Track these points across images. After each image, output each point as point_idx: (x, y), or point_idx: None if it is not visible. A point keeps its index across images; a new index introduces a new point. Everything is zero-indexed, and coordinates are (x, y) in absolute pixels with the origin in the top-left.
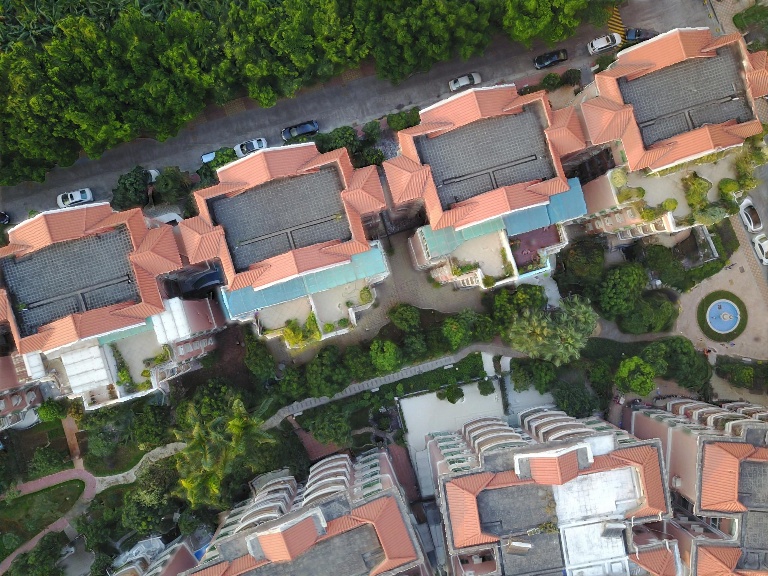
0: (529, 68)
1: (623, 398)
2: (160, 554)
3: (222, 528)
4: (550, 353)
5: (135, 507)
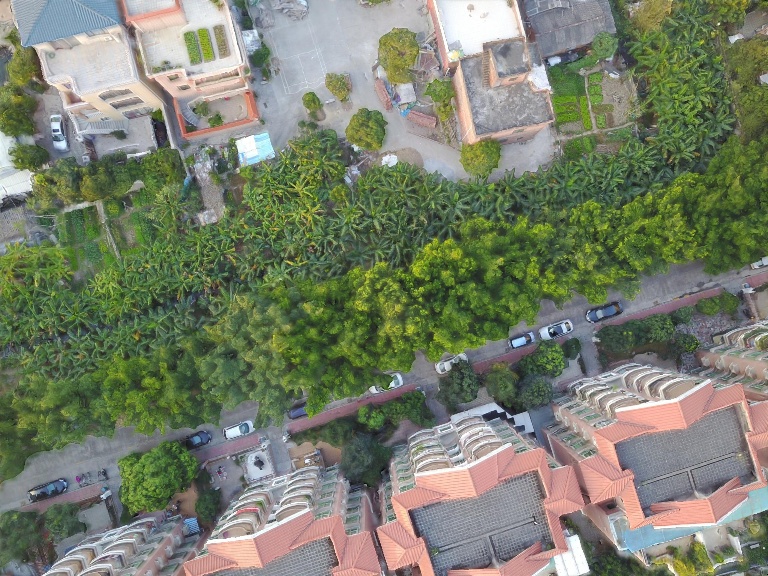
0: None
1: None
2: None
3: None
4: None
5: None
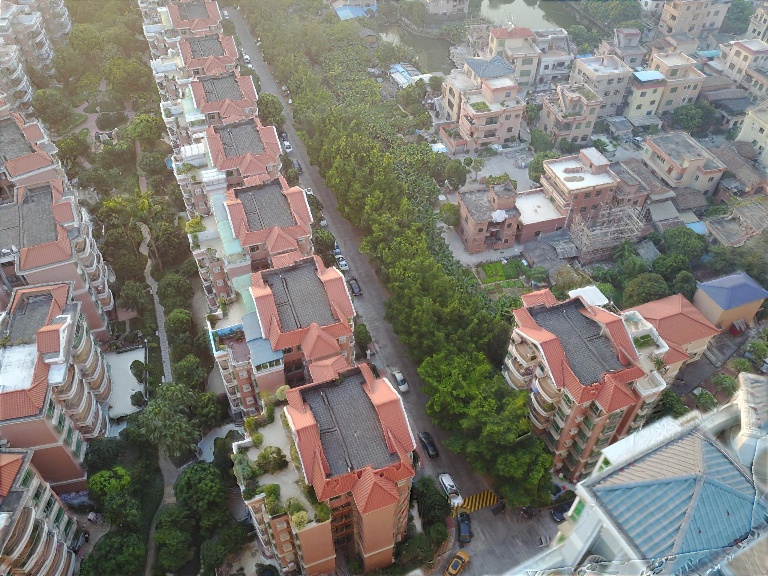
0: (418, 427)
1: (94, 515)
2: None
3: None
4: None
5: None
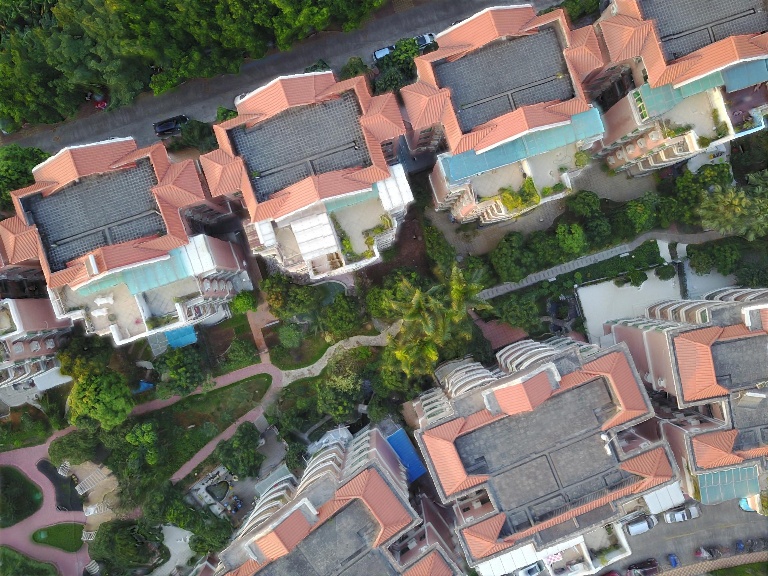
0: None
1: None
2: (353, 440)
3: (425, 405)
4: (745, 227)
5: (332, 392)
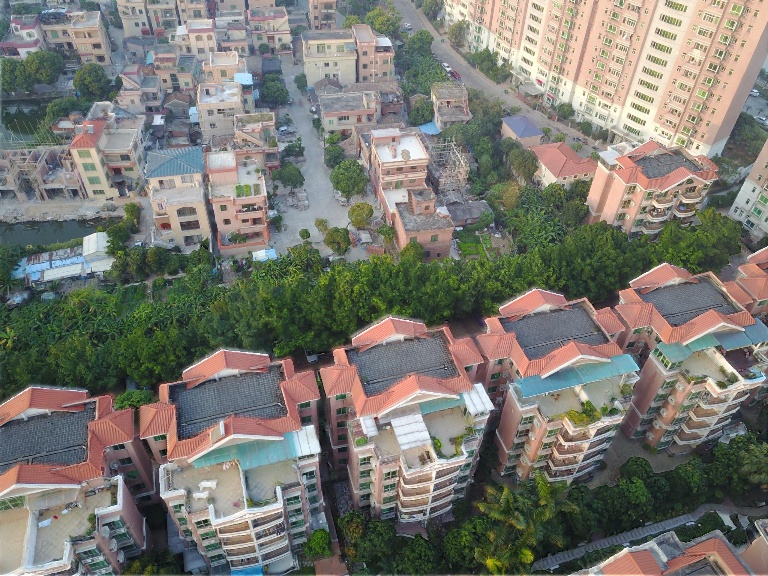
0: None
1: None
2: None
3: None
4: None
5: None
